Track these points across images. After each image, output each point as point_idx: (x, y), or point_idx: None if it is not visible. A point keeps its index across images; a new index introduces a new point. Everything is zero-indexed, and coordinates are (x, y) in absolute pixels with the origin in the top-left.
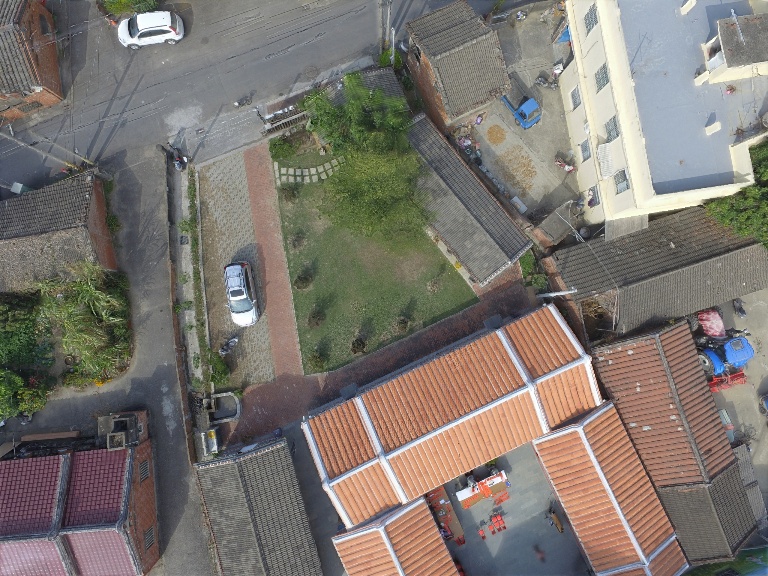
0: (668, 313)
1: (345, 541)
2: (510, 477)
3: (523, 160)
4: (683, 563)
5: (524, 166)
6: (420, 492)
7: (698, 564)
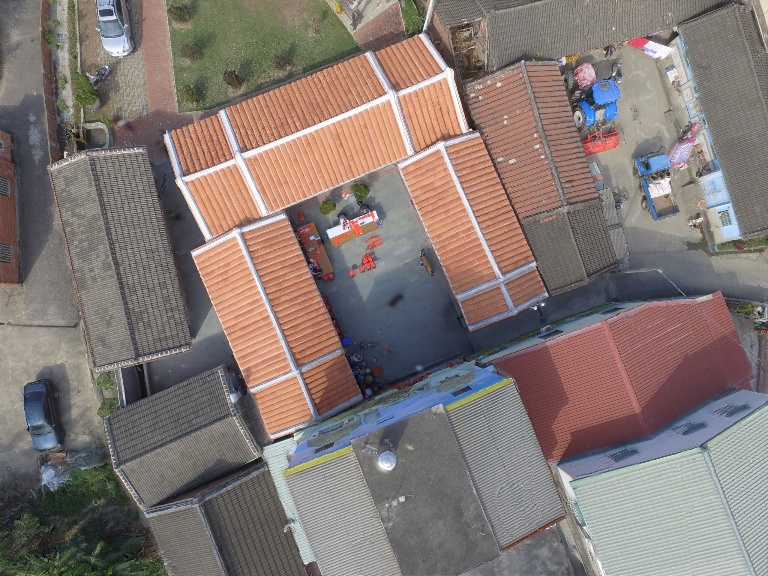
0: None
1: (203, 252)
2: (384, 223)
3: None
4: (542, 291)
5: None
6: (281, 205)
7: (557, 293)
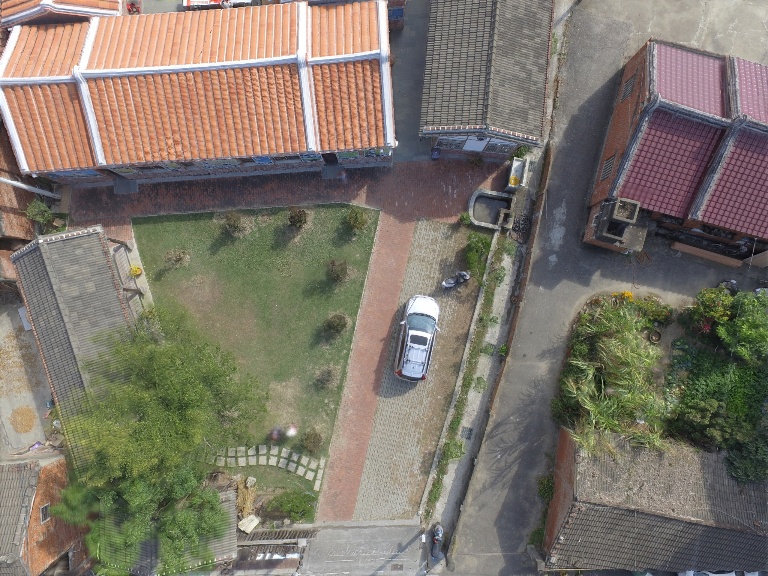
0: None
1: None
2: None
3: (3, 374)
4: None
5: (5, 366)
6: (280, 8)
7: None
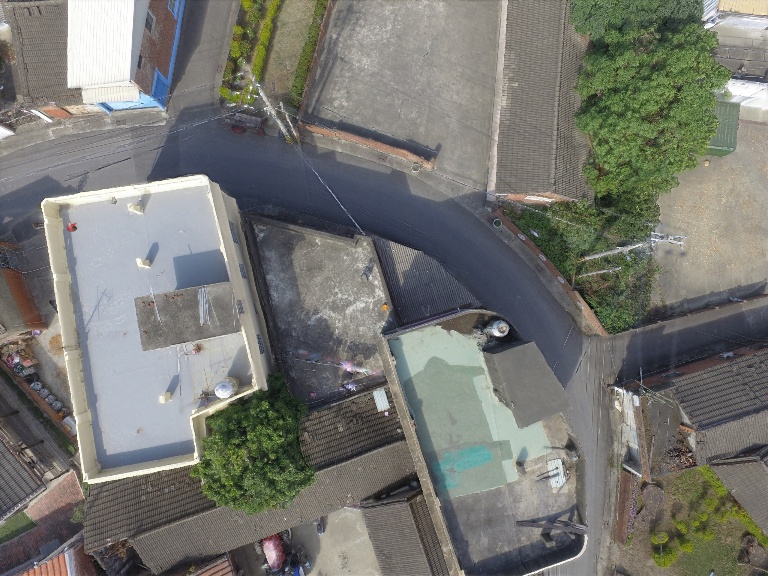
0: (203, 552)
1: None
2: None
3: None
4: None
5: None
6: None
7: None
